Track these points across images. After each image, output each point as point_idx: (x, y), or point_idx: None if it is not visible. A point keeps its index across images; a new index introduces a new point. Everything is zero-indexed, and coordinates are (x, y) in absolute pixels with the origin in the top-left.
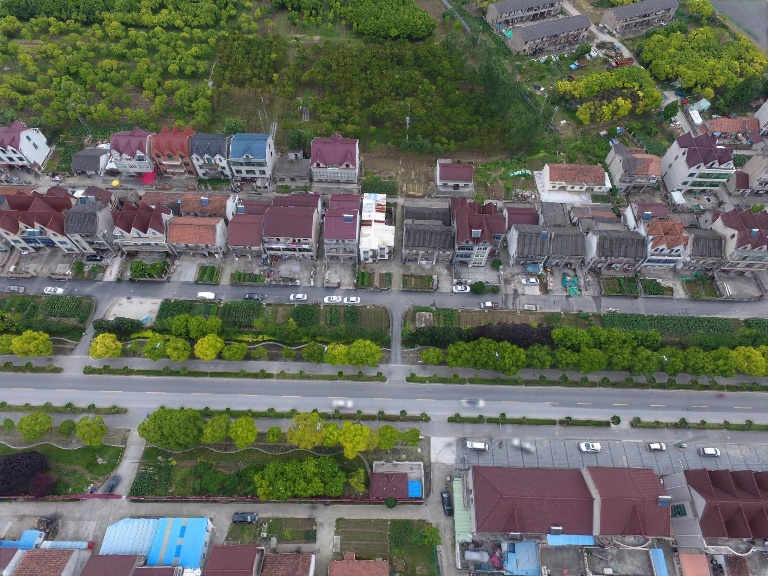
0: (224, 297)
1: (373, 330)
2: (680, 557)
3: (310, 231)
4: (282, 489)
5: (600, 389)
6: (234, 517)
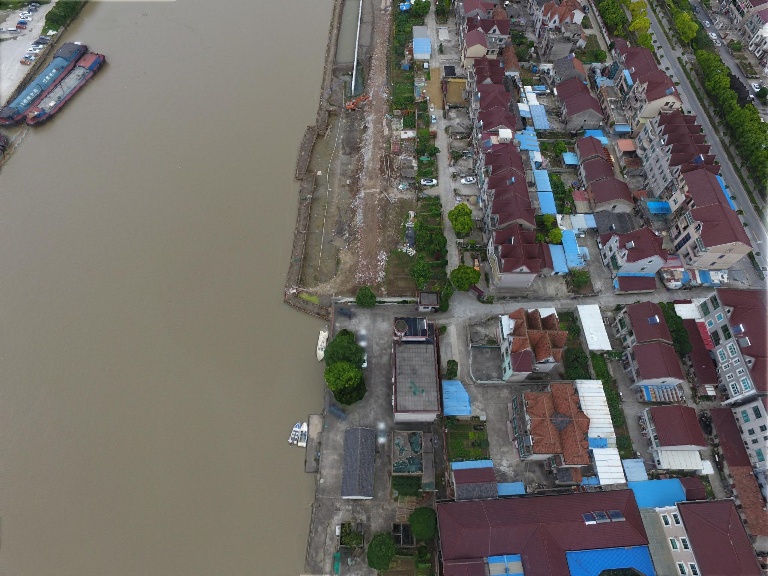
0: (690, 0)
1: (704, 39)
2: (629, 139)
3: (759, 4)
4: (609, 2)
5: (717, 138)
6: (586, 5)
